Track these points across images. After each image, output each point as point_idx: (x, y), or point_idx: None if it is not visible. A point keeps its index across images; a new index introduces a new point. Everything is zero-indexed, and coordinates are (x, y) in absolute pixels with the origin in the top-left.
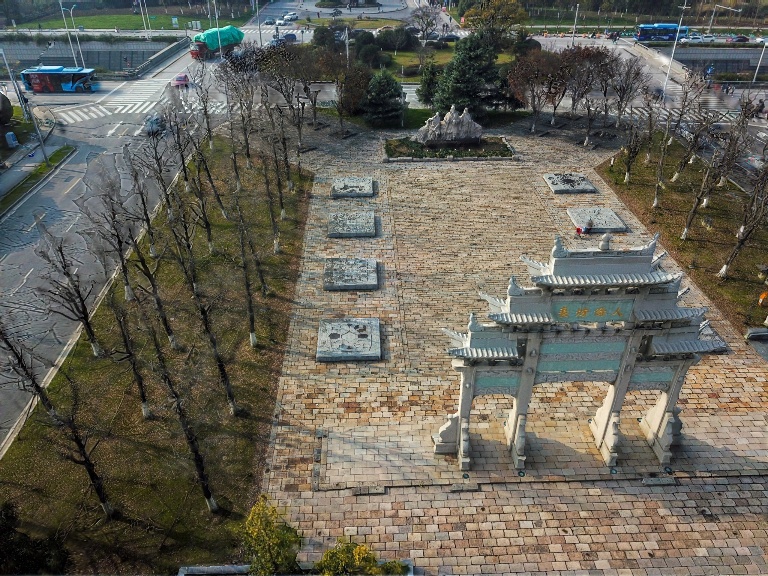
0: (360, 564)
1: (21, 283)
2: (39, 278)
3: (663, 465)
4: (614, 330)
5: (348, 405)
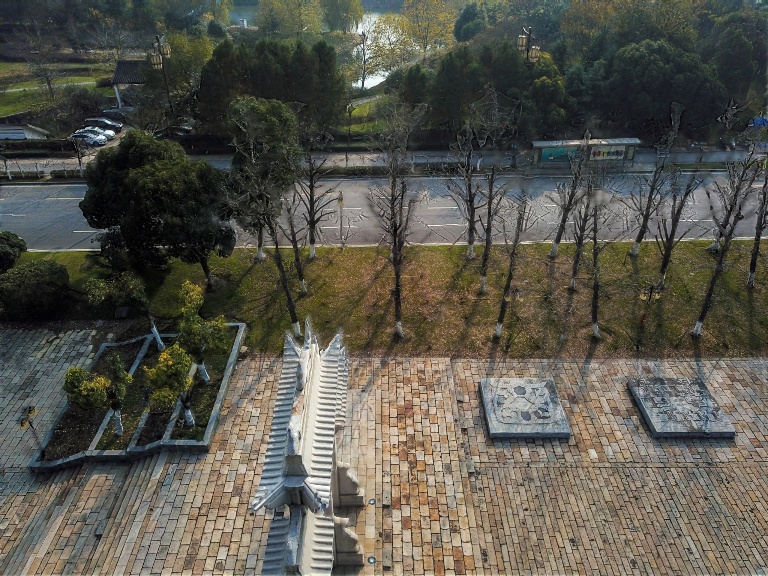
0: None
1: None
2: None
3: None
4: None
5: (409, 408)
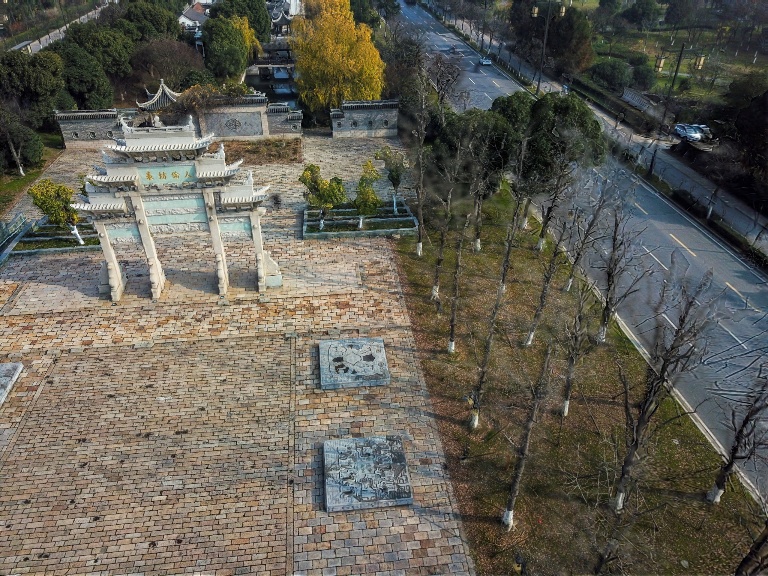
0: None
1: None
2: None
3: None
4: None
5: (346, 306)
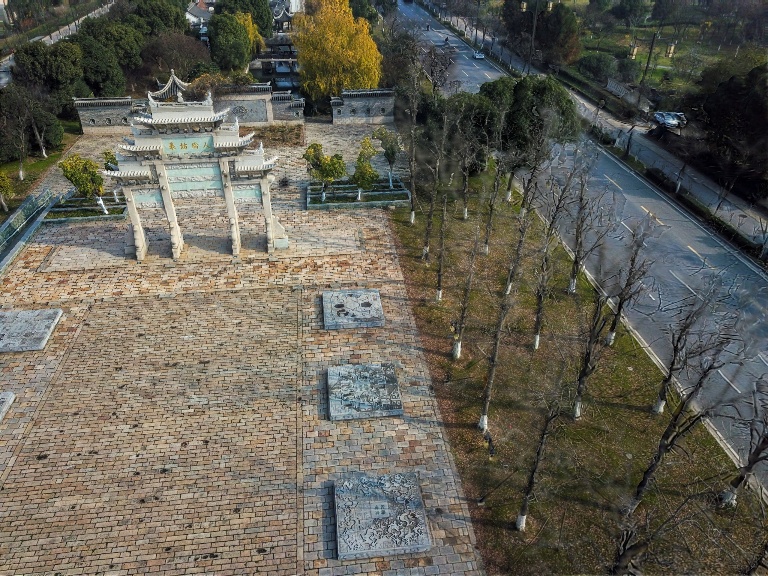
0: None
1: (767, 360)
2: (761, 372)
3: None
4: None
5: (346, 264)
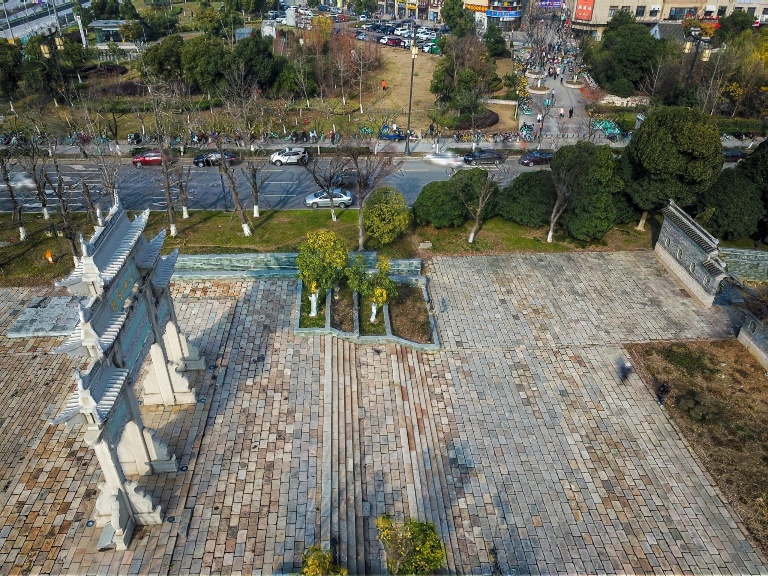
0: (321, 573)
1: None
2: None
3: (207, 369)
4: (139, 293)
5: None
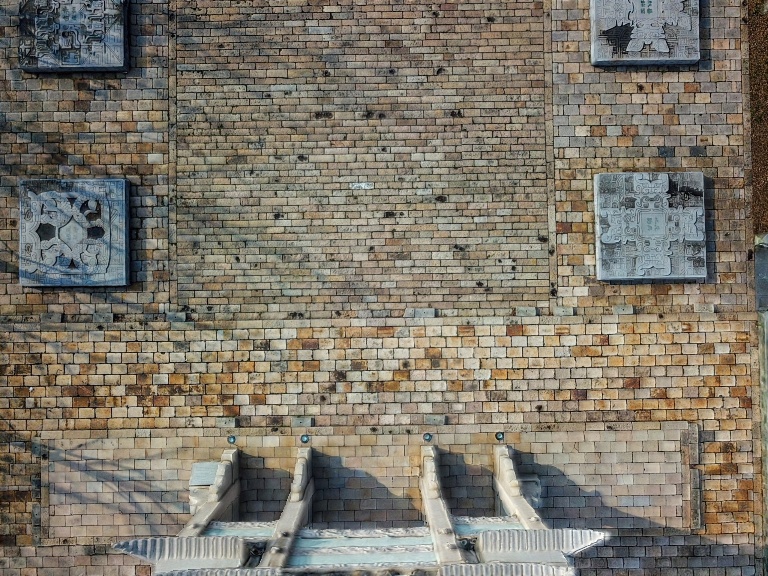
0: None
1: None
2: None
3: None
4: None
5: (77, 392)
